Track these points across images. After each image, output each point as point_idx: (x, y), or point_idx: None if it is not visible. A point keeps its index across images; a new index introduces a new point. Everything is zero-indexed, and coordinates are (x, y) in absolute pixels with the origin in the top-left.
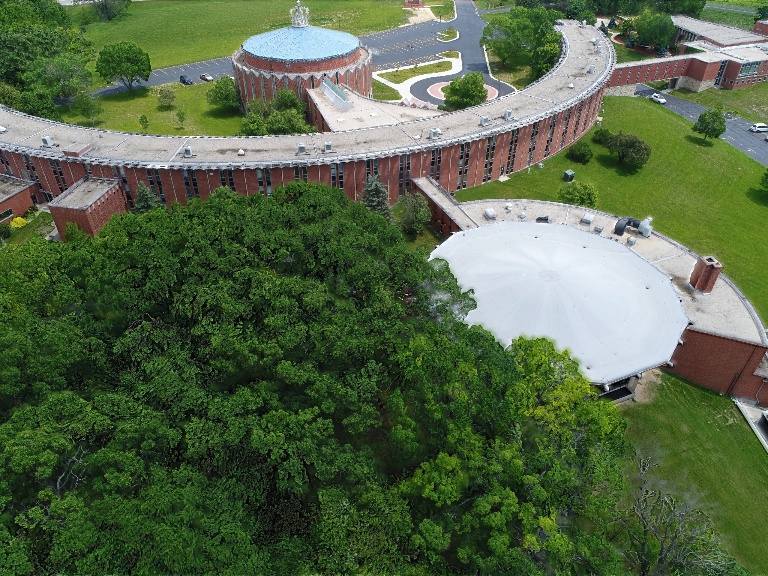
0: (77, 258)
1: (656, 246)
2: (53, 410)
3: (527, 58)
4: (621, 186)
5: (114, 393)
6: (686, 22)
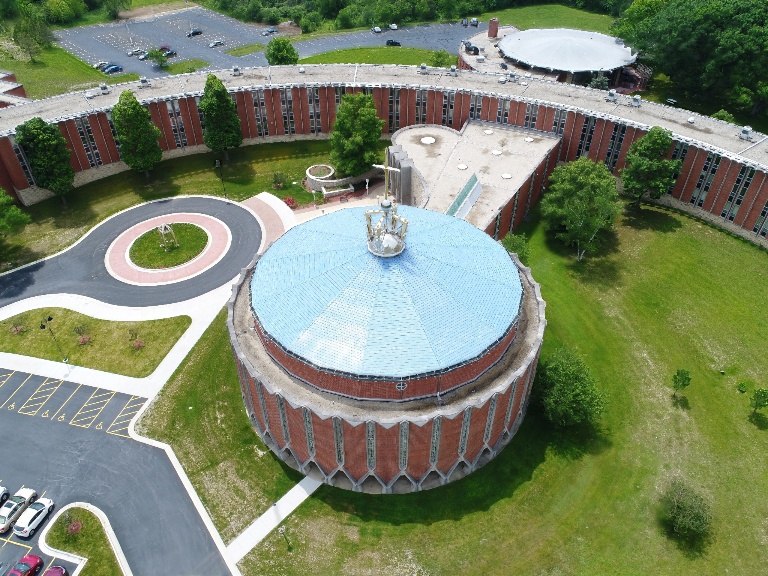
0: None
1: None
2: None
3: None
4: None
5: None
6: None
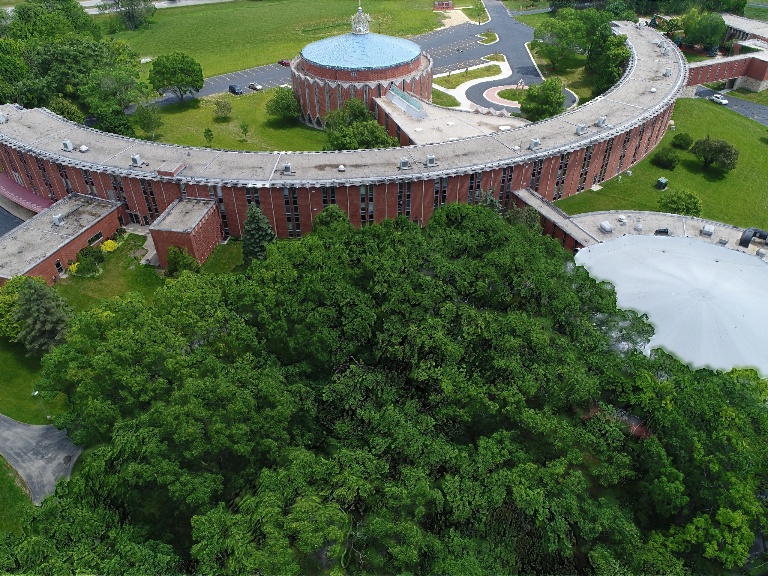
0: (248, 294)
1: None
2: (303, 474)
3: (574, 60)
4: (713, 192)
5: (344, 448)
6: (733, 20)
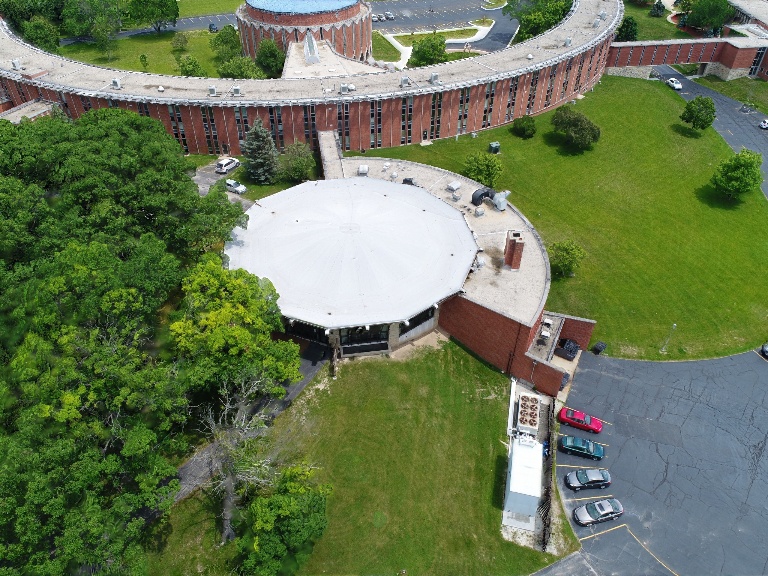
0: None
1: (504, 220)
2: None
3: None
4: (552, 165)
5: None
6: (753, 4)
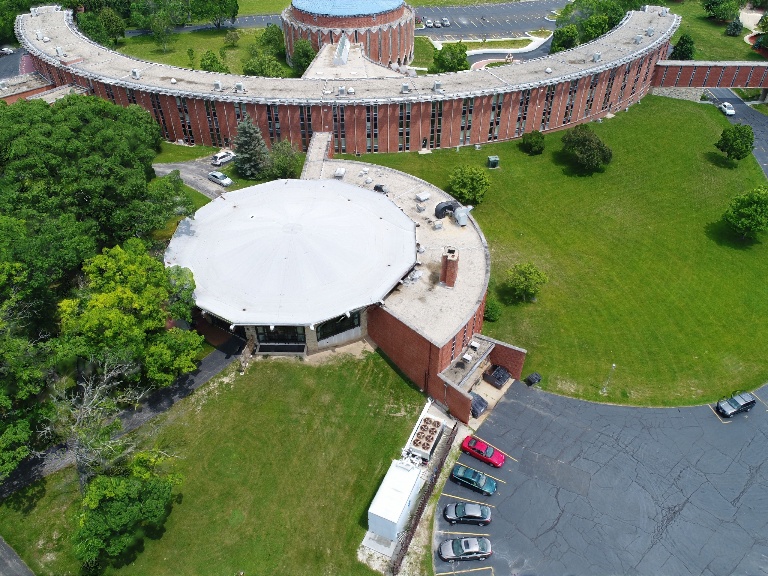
0: None
1: (461, 235)
2: None
3: None
4: (552, 184)
5: None
6: None
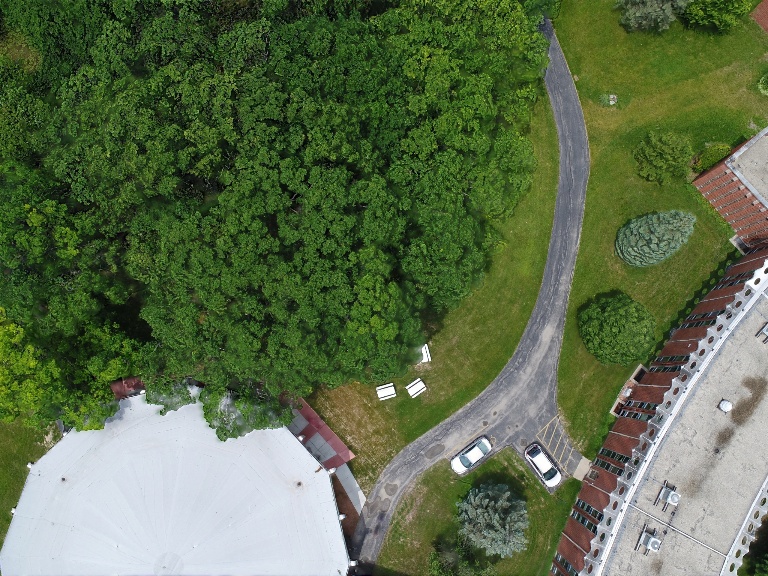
0: None
1: None
2: None
3: None
4: None
5: (211, 0)
6: None
